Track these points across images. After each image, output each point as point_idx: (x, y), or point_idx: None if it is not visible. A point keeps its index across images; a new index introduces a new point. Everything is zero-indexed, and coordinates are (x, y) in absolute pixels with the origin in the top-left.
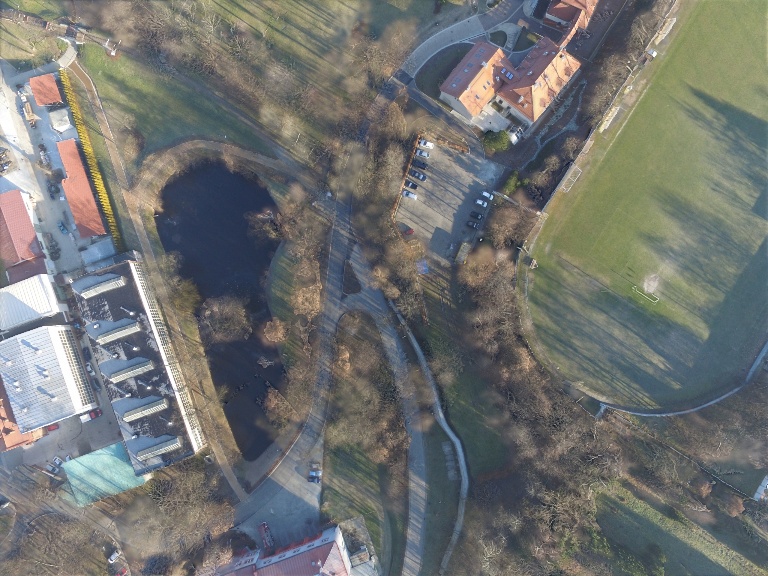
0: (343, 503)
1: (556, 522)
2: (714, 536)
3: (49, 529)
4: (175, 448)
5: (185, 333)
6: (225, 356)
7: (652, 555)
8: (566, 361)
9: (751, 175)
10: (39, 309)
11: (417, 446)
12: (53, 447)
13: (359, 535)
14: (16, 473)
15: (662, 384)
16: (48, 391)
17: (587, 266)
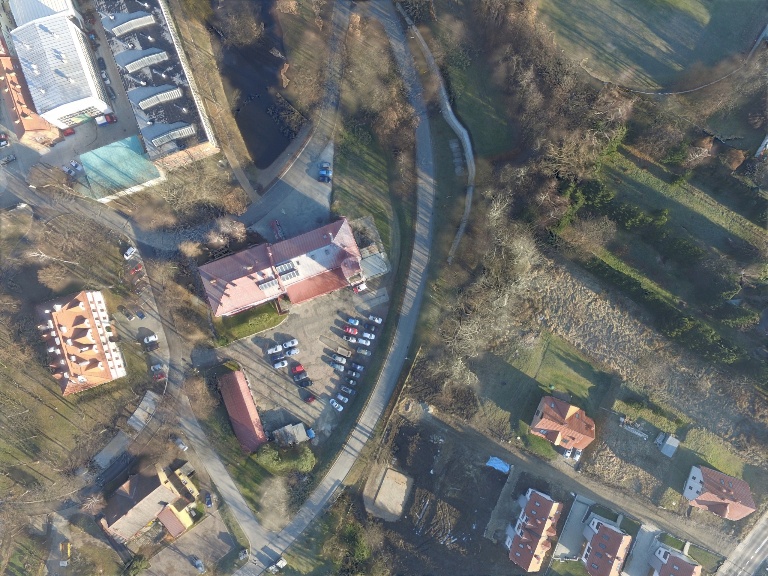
0: (353, 202)
1: (562, 172)
2: (715, 199)
3: (66, 228)
4: (189, 134)
5: (198, 44)
6: (237, 69)
7: (655, 214)
8: (571, 44)
9: None
10: (55, 8)
11: (425, 145)
12: (69, 152)
13: (369, 233)
14: (33, 170)
15: (664, 66)
16: (65, 74)
17: None
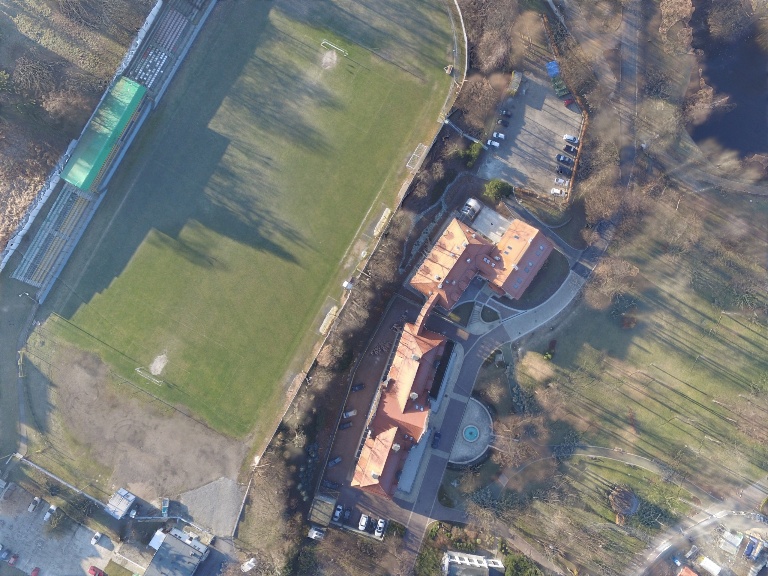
0: None
1: None
2: None
3: None
4: None
5: (767, 4)
6: None
7: None
8: None
9: (232, 177)
10: None
11: None
12: None
13: None
14: None
15: None
16: None
17: (395, 72)
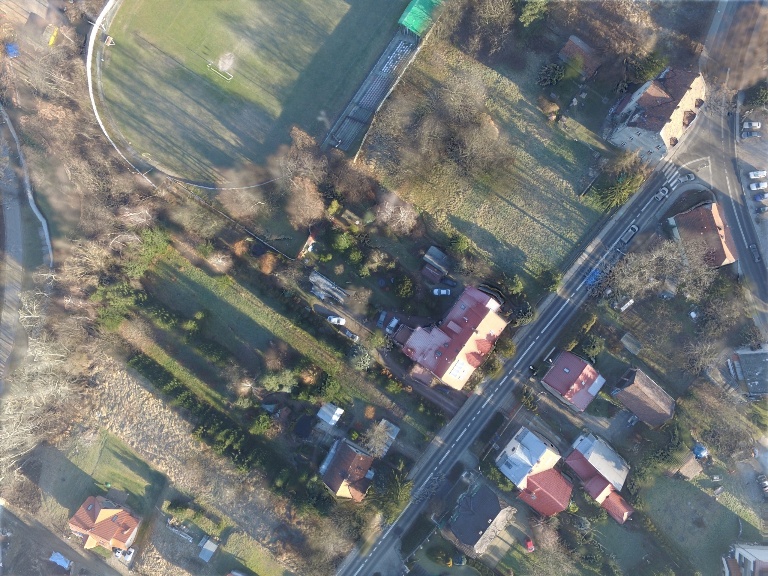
0: None
1: (87, 274)
2: (262, 300)
3: None
4: None
5: None
6: None
7: None
8: (138, 136)
9: None
10: None
11: (15, 231)
12: None
13: None
14: None
15: (232, 160)
16: None
17: (163, 44)
